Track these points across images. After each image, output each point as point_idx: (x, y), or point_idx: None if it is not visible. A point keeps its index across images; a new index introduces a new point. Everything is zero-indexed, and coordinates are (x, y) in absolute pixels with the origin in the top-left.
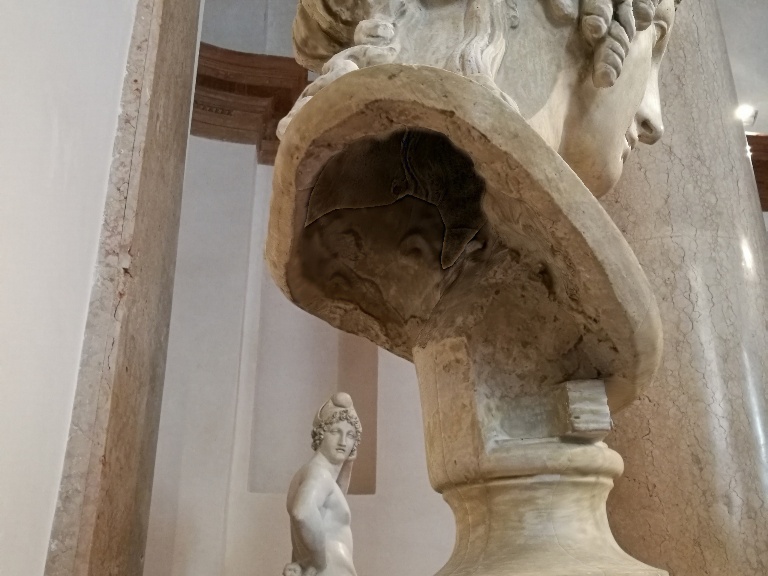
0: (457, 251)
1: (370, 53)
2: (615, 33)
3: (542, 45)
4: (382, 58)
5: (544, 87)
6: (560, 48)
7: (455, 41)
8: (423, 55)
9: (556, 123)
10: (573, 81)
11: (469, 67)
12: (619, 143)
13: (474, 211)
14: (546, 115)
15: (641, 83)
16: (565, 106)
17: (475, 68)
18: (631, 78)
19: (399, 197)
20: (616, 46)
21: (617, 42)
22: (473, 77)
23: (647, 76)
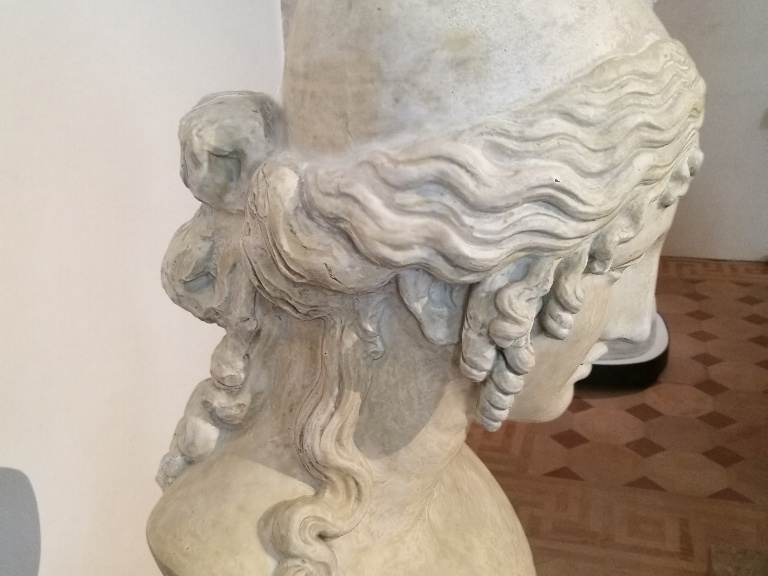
0: None
1: (218, 414)
2: (496, 381)
3: (418, 366)
4: (231, 418)
5: (424, 409)
6: (445, 362)
7: (311, 378)
8: (279, 394)
9: (451, 423)
10: (467, 387)
11: (306, 456)
12: (552, 402)
13: None
14: (431, 429)
15: (575, 357)
16: (462, 405)
17: (312, 458)
18: (553, 367)
19: None
20: (494, 400)
21: (498, 392)
22: (279, 534)
23: (589, 342)
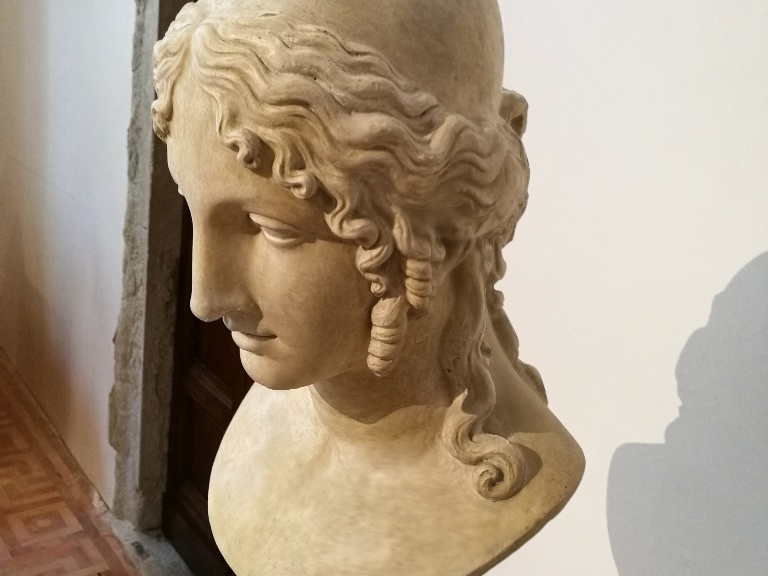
0: (417, 430)
1: None
2: None
3: None
4: None
5: None
6: None
7: None
8: None
9: None
10: None
11: None
12: None
13: (407, 387)
14: None
15: None
16: None
17: None
18: None
19: (489, 361)
20: None
21: None
22: None
23: None
